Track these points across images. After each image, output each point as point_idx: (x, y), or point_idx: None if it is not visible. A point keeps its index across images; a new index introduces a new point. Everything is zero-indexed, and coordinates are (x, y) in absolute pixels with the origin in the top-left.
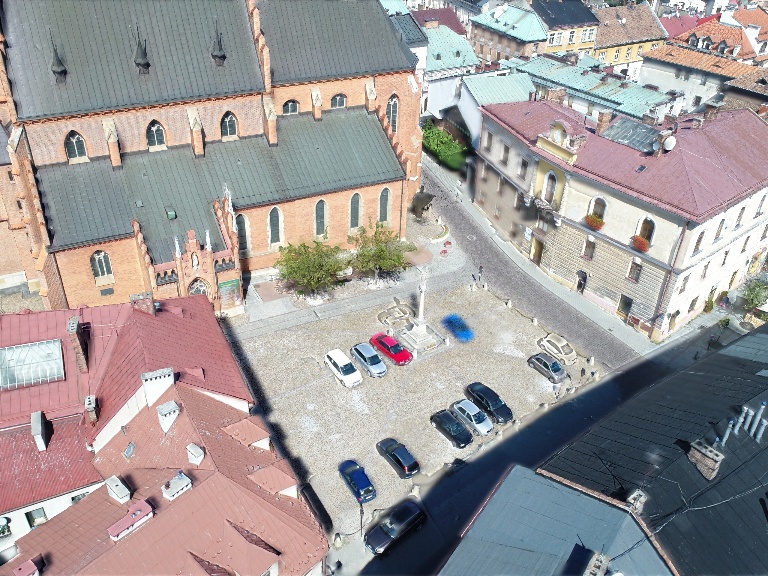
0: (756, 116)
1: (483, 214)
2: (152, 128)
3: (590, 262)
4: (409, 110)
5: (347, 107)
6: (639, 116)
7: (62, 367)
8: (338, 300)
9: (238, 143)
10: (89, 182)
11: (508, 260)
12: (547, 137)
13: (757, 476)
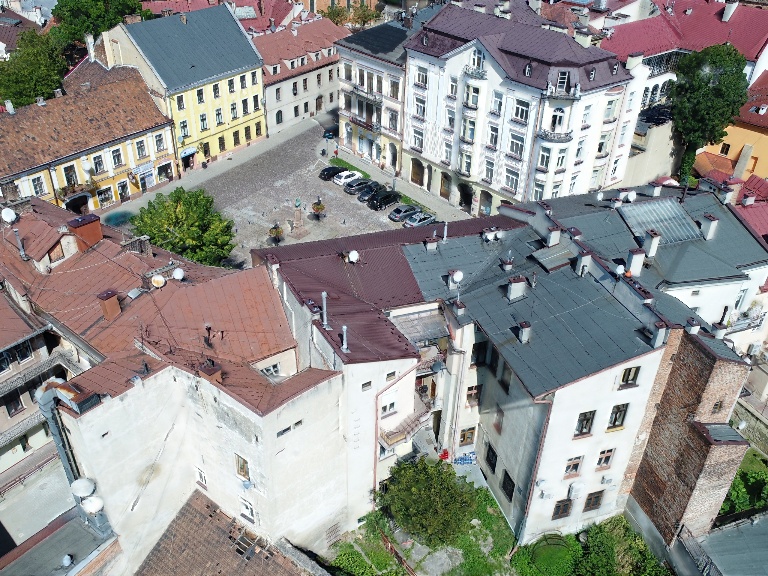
0: None
1: None
2: None
3: None
4: None
5: None
6: None
7: None
8: None
9: None
10: None
11: None
12: None
13: None
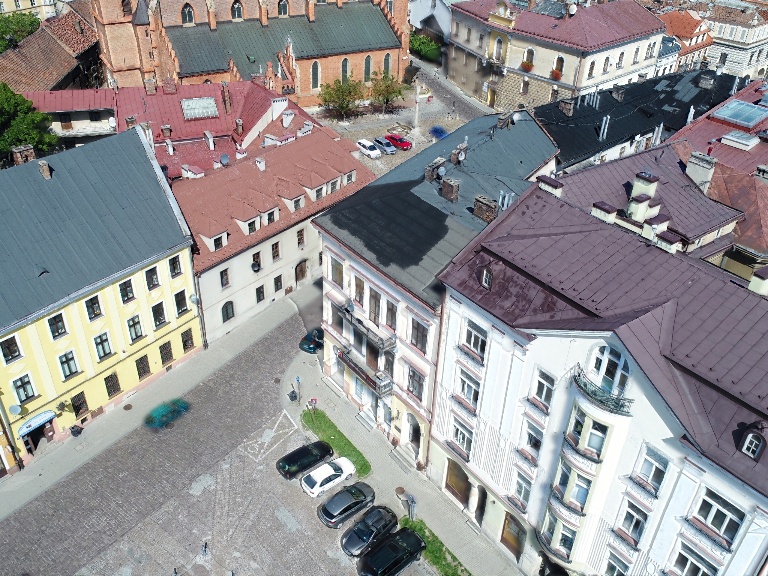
0: (635, 1)
1: (454, 84)
2: (235, 6)
3: (526, 96)
4: (401, 6)
5: (359, 1)
6: None
7: (217, 111)
8: (360, 123)
9: (289, 20)
10: (197, 38)
11: (472, 106)
12: (495, 13)
13: (594, 120)
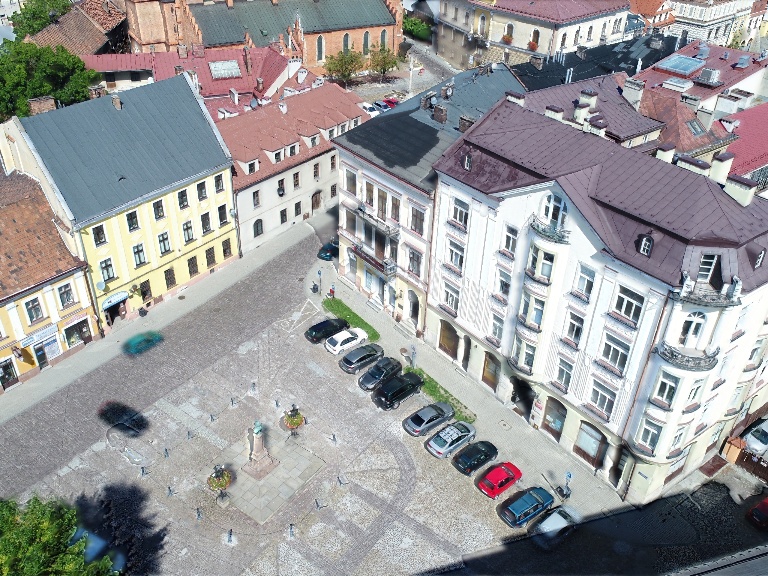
0: None
1: (444, 59)
2: None
3: None
4: None
5: None
6: None
7: (240, 72)
8: (360, 91)
9: None
10: (217, 15)
11: None
12: None
13: (561, 74)
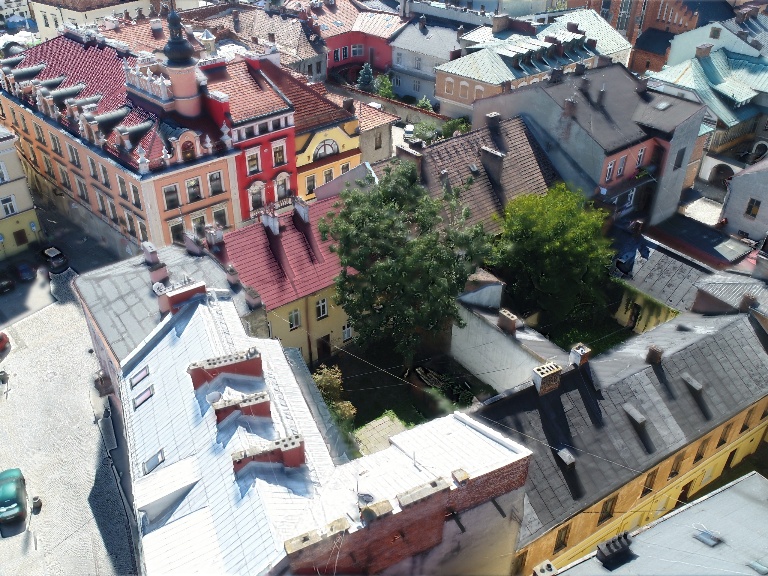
0: None
1: None
2: None
3: None
4: None
5: None
6: (438, 2)
7: None
8: None
9: None
10: None
11: None
12: None
13: None
